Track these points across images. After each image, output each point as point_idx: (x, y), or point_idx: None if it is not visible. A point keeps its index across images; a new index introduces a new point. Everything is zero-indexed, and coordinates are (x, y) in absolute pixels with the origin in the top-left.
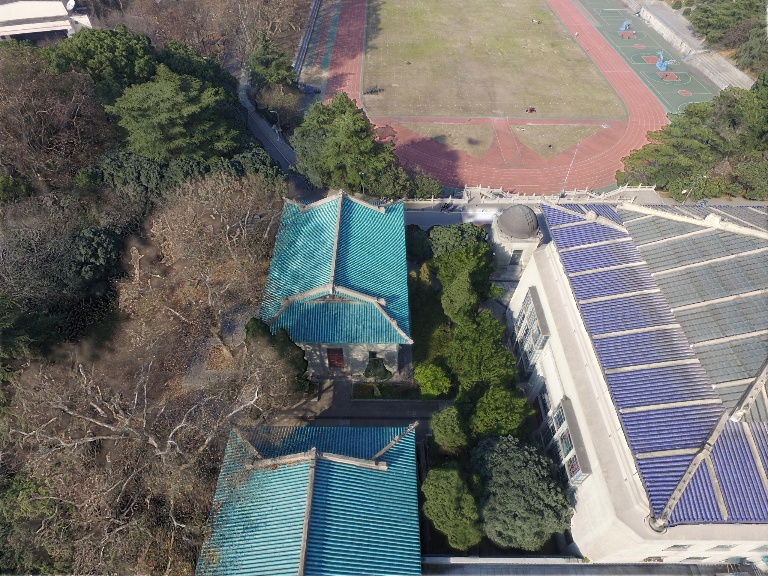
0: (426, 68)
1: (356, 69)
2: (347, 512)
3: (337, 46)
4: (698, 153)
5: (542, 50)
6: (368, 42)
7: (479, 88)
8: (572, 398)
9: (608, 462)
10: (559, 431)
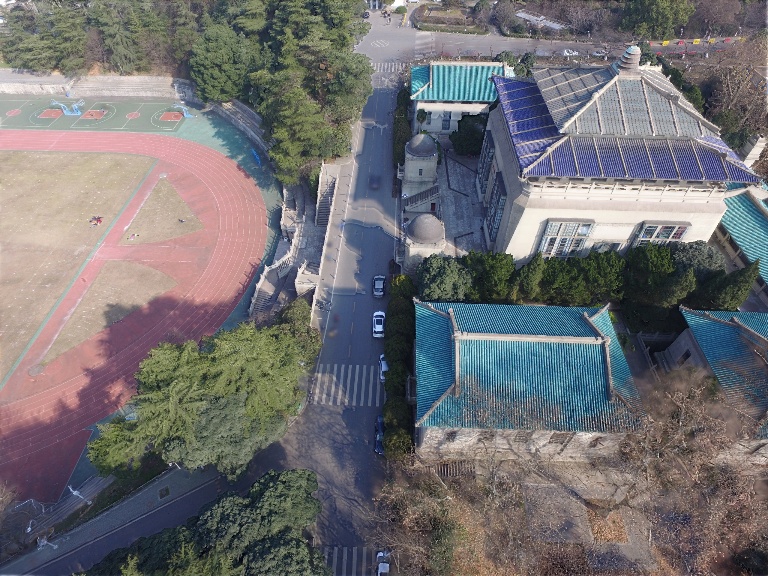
0: None
1: None
2: None
3: None
4: None
5: None
6: None
7: (2, 258)
8: (647, 218)
9: (695, 208)
10: (654, 236)
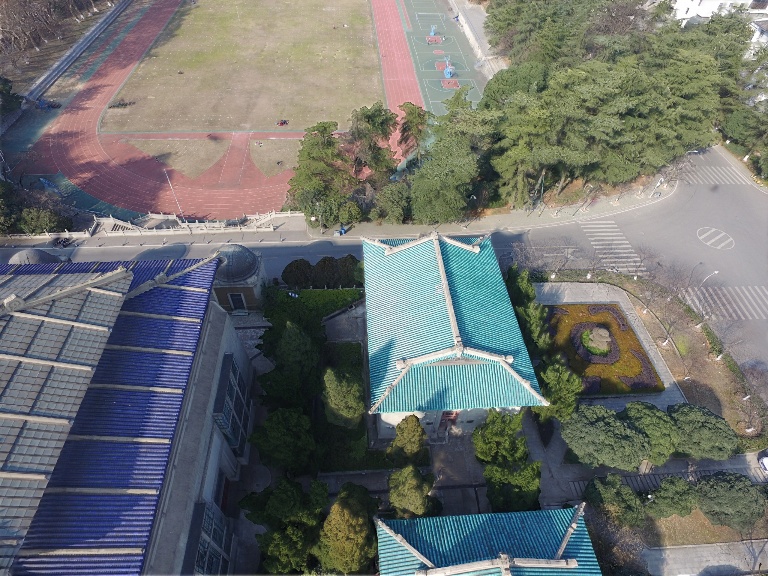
0: (197, 78)
1: (118, 80)
2: None
3: (114, 55)
4: (332, 176)
5: (335, 57)
6: (151, 50)
7: (241, 99)
8: None
9: None
10: None
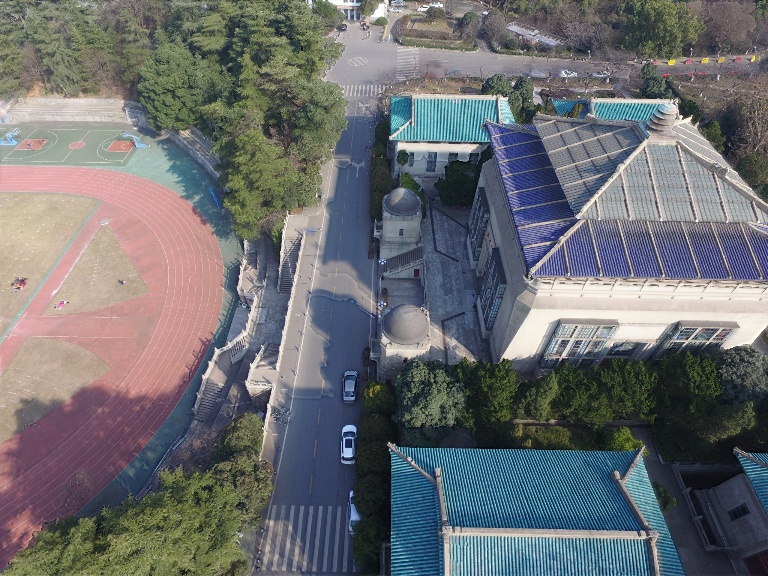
0: None
1: None
2: None
3: None
4: None
5: None
6: None
7: None
8: (683, 318)
9: (745, 307)
10: None
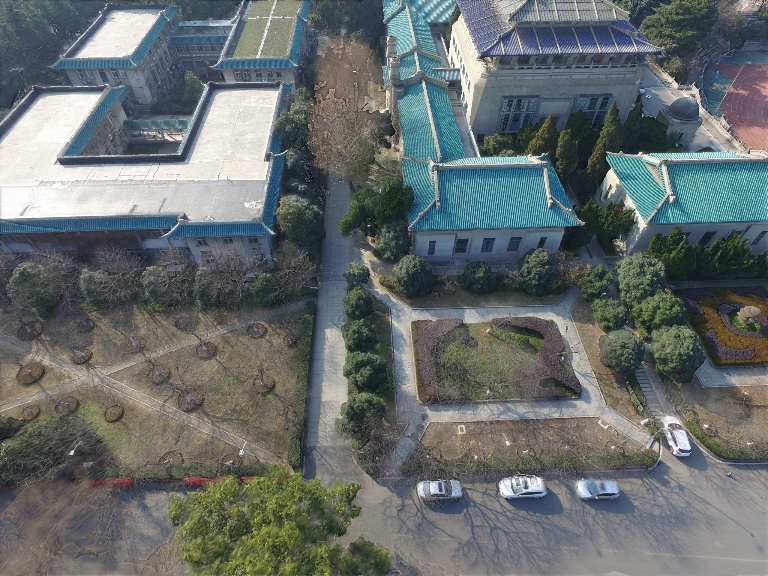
0: None
1: None
2: (449, 1)
3: None
4: None
5: None
6: None
7: None
8: None
9: None
10: None
